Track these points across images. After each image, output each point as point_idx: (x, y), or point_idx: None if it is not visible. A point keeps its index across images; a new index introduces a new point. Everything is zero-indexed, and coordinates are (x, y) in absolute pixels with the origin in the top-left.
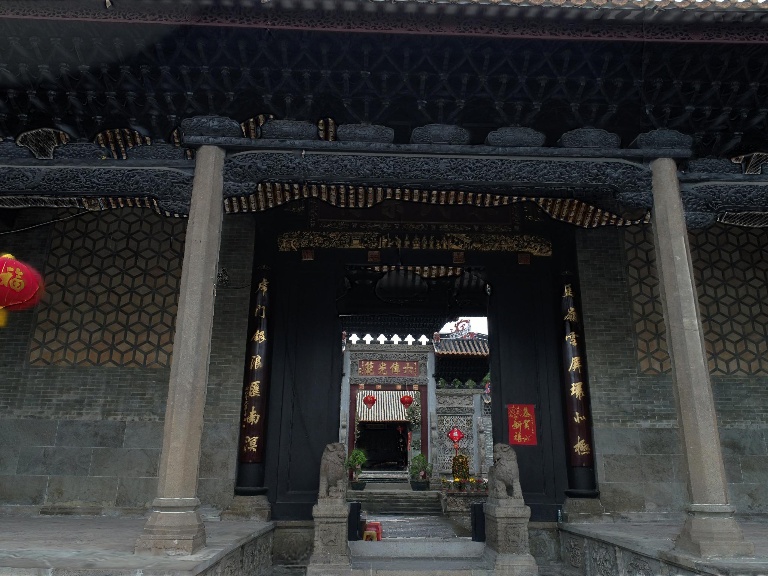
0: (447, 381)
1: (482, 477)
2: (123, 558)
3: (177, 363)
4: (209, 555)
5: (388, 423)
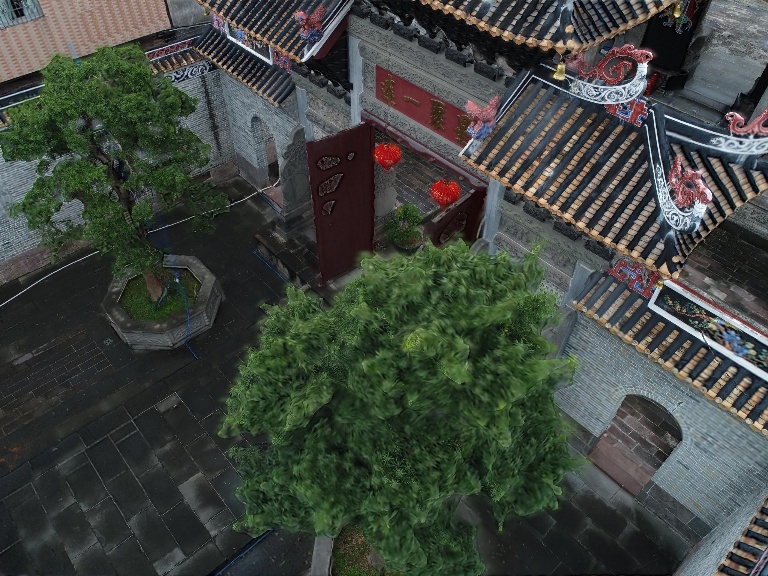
0: None
1: None
2: None
3: None
4: None
5: None
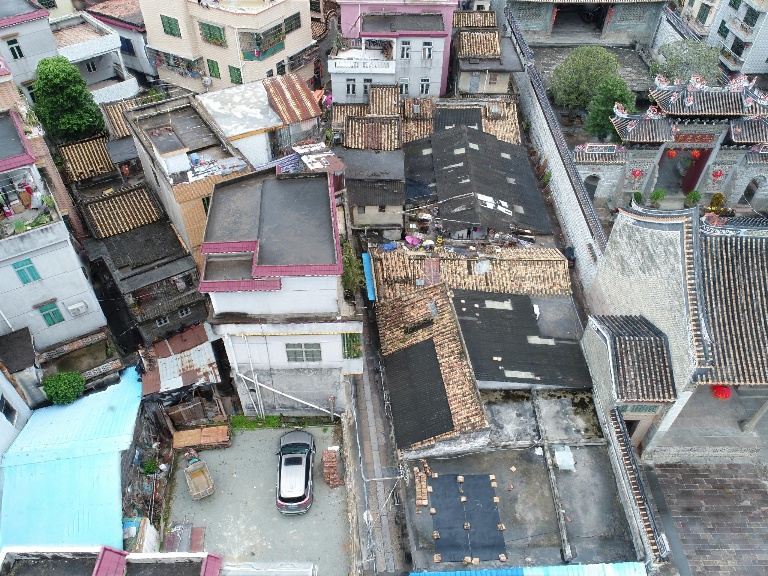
0: (728, 146)
1: (727, 203)
2: (744, 436)
3: (764, 409)
4: (757, 432)
5: (597, 3)
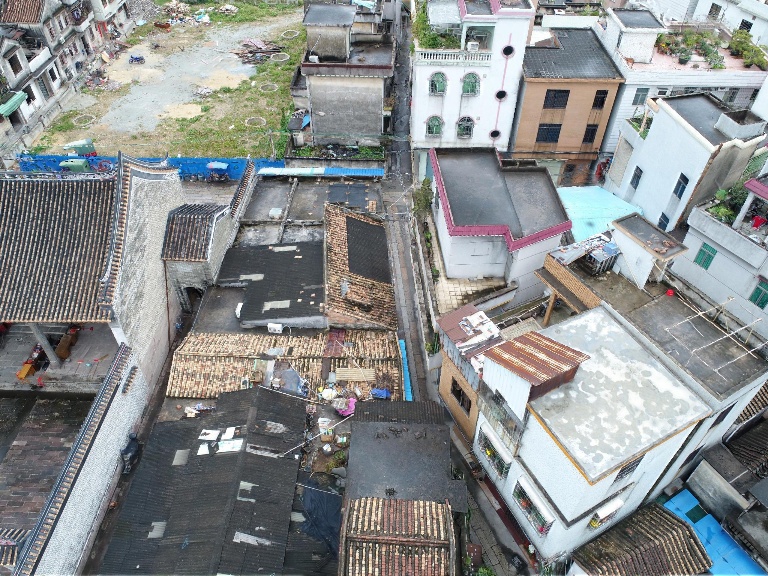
0: None
1: None
2: None
3: None
4: None
5: None
